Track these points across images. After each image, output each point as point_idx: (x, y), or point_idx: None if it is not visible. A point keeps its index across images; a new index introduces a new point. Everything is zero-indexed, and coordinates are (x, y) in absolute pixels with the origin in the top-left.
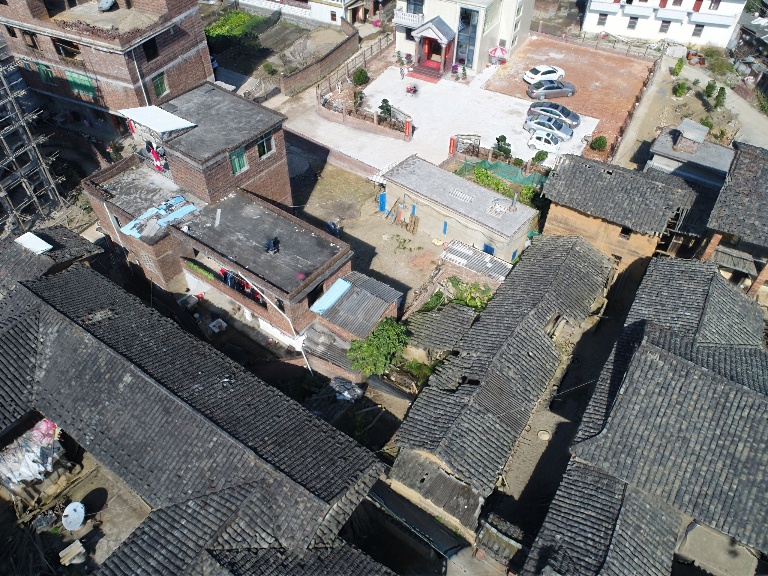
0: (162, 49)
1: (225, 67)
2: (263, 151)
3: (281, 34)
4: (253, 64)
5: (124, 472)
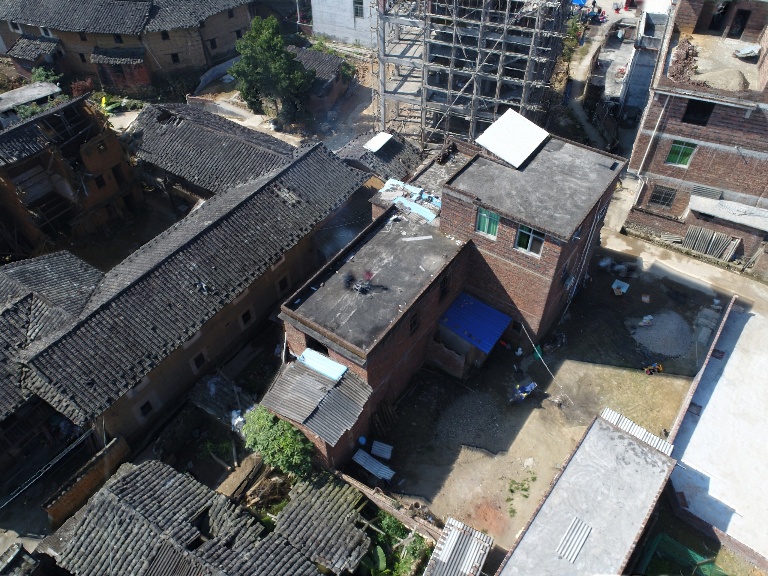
0: (716, 122)
1: None
2: (527, 245)
3: None
4: None
5: (140, 249)
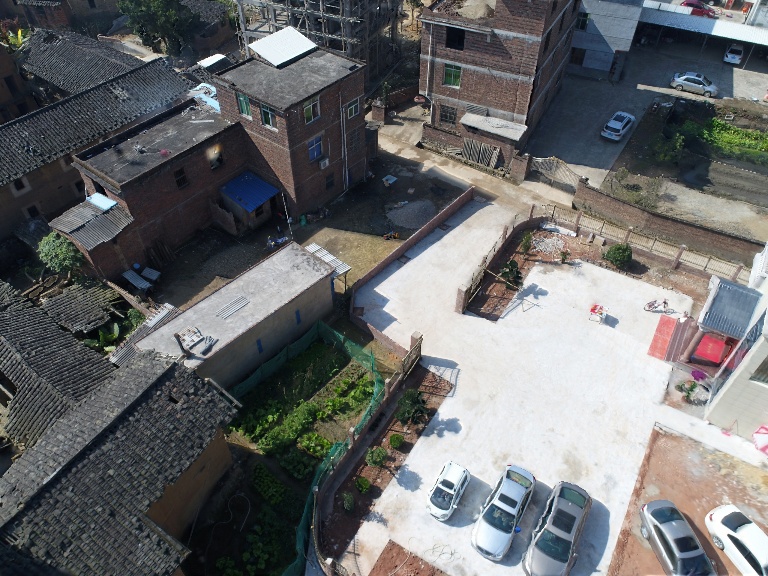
0: (469, 47)
1: (628, 150)
2: None
3: (766, 189)
4: (649, 170)
5: None
